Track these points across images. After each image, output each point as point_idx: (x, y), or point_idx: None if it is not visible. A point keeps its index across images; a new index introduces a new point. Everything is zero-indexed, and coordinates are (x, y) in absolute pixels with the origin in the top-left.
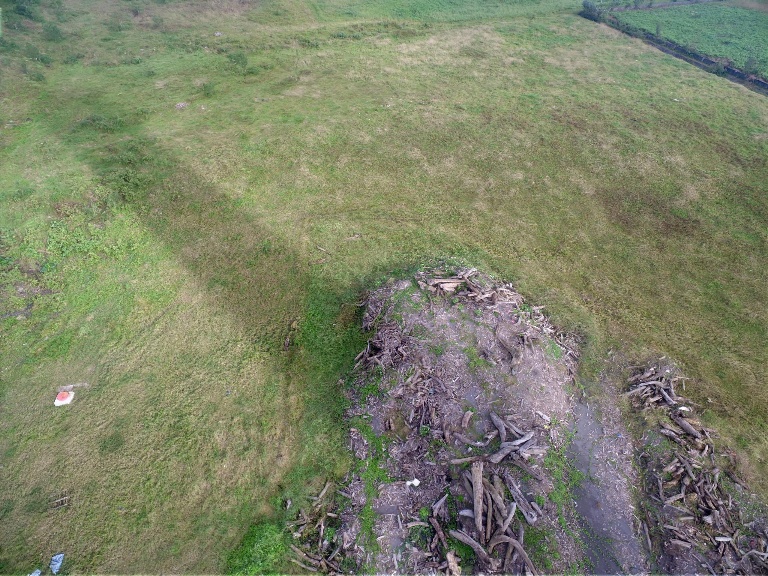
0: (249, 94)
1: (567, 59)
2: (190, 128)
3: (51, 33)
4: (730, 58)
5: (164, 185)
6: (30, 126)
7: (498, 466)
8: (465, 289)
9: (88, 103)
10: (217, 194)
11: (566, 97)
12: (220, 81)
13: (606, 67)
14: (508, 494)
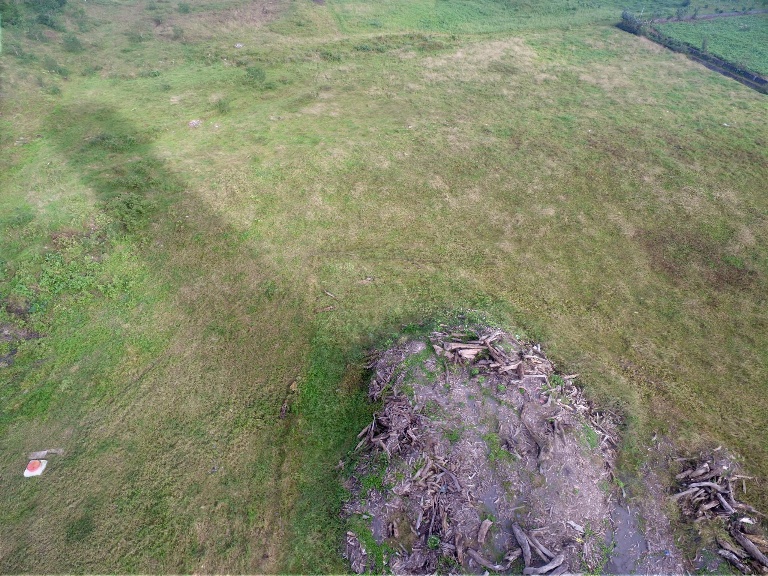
0: (265, 111)
1: (604, 76)
2: (201, 148)
3: (71, 44)
4: None
5: (168, 213)
6: (40, 143)
7: None
8: (487, 357)
9: (101, 119)
10: (223, 225)
11: (603, 120)
12: (236, 97)
13: (647, 86)
14: None
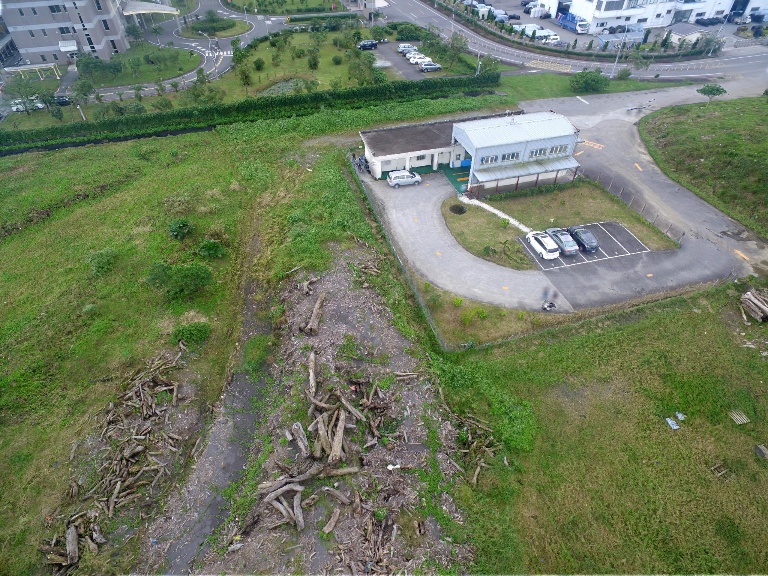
0: None
1: None
2: None
3: None
4: None
5: None
6: None
7: None
8: None
9: None
10: None
11: None
12: None
13: None
14: (311, 443)
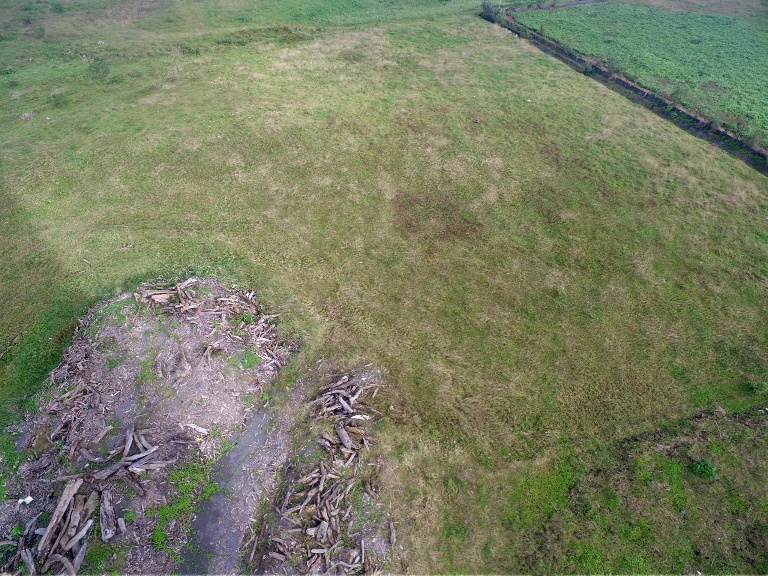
0: (102, 103)
1: (441, 61)
2: (24, 139)
3: None
4: (604, 57)
5: None
6: None
7: (107, 482)
8: (177, 300)
9: None
10: (14, 206)
11: (420, 100)
12: (77, 90)
13: (476, 68)
14: (97, 511)
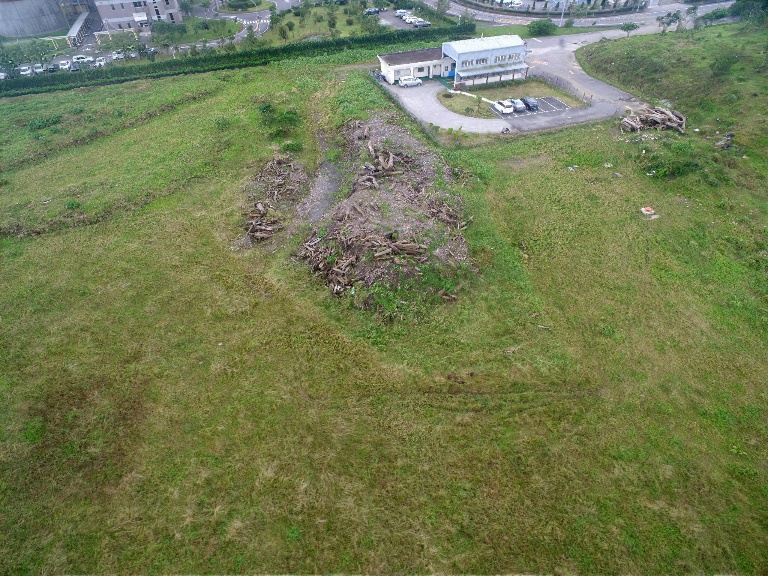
0: None
1: None
2: None
3: None
4: None
5: None
6: None
7: None
8: None
9: None
10: None
11: None
12: None
13: None
14: None
